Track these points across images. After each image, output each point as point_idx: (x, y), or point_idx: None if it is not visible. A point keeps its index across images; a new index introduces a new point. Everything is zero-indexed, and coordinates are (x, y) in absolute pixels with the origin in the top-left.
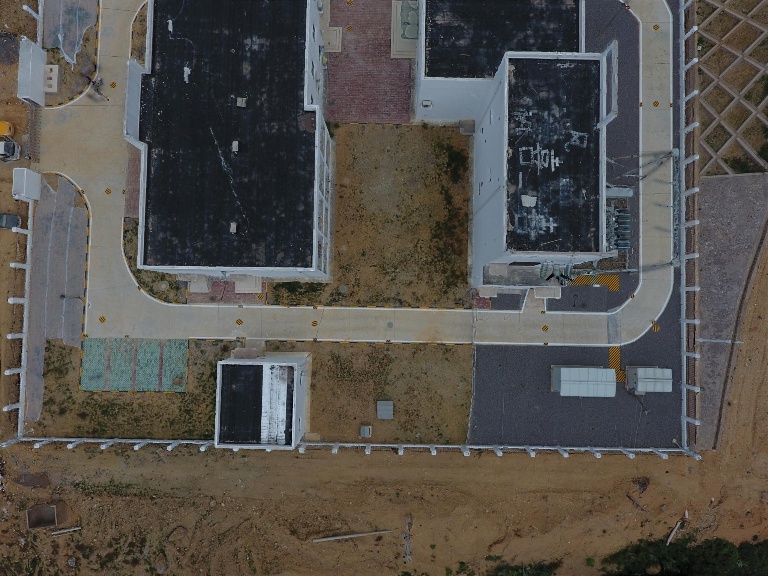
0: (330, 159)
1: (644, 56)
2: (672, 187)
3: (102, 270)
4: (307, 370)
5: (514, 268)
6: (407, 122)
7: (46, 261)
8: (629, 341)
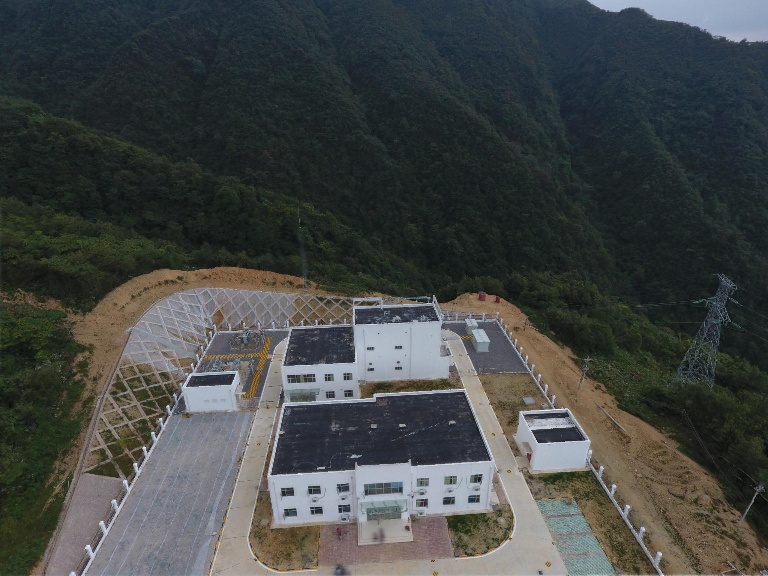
0: None
1: None
2: None
3: (506, 570)
4: None
5: None
6: None
7: None
8: None
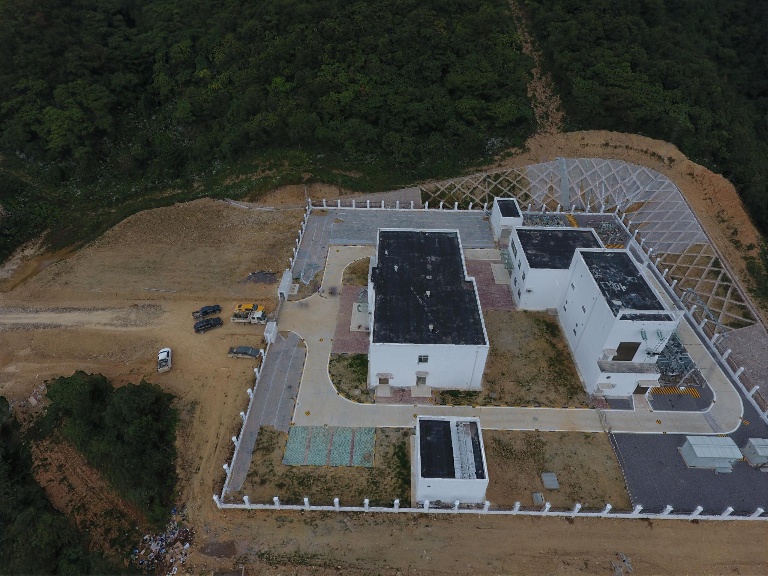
0: None
1: None
2: (700, 341)
3: (311, 382)
4: None
5: (619, 363)
6: (513, 310)
7: (272, 376)
8: (730, 431)
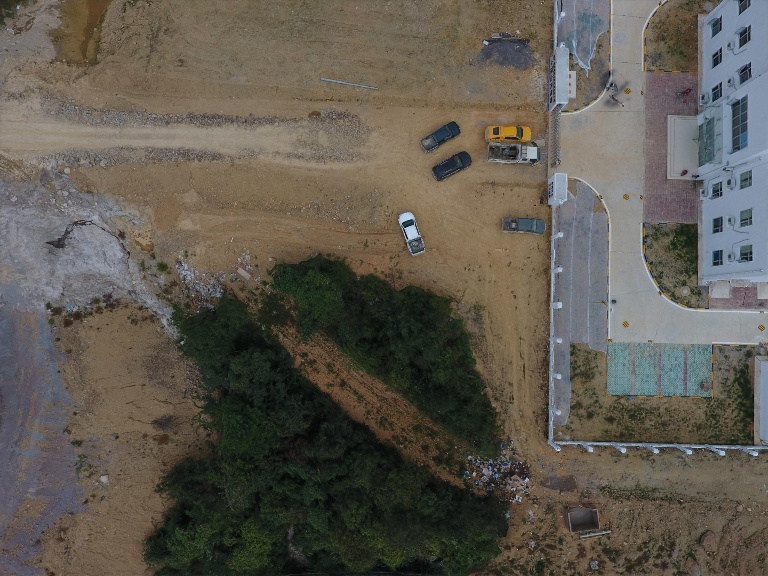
0: None
1: None
2: None
3: (623, 275)
4: None
5: None
6: None
7: (569, 266)
8: None
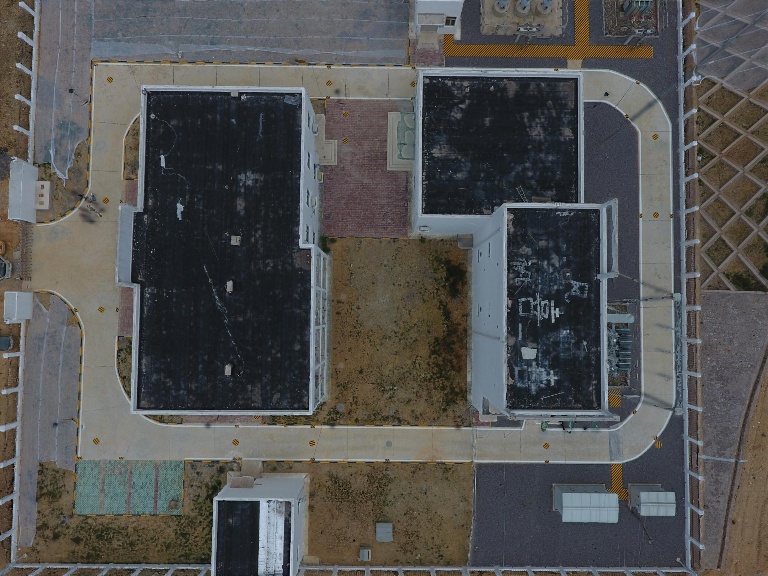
0: (326, 275)
1: (643, 166)
2: None
3: (96, 390)
4: (305, 495)
5: None
6: (404, 236)
7: (39, 382)
8: (631, 458)
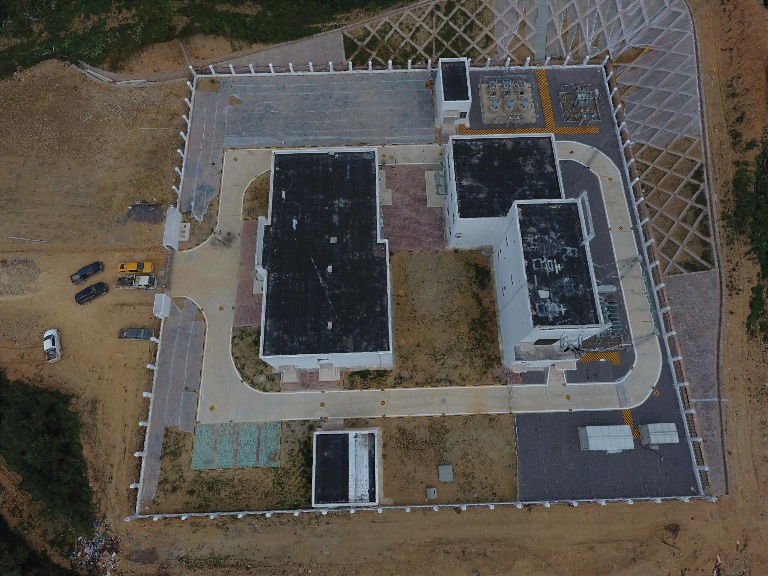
0: None
1: (606, 198)
2: (645, 285)
3: (214, 368)
4: (380, 440)
5: (538, 347)
6: (443, 249)
7: (170, 363)
8: (637, 404)
